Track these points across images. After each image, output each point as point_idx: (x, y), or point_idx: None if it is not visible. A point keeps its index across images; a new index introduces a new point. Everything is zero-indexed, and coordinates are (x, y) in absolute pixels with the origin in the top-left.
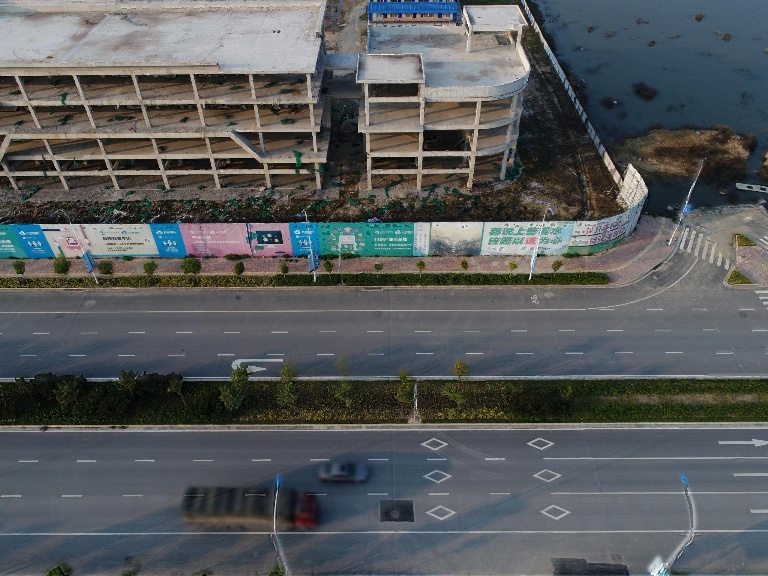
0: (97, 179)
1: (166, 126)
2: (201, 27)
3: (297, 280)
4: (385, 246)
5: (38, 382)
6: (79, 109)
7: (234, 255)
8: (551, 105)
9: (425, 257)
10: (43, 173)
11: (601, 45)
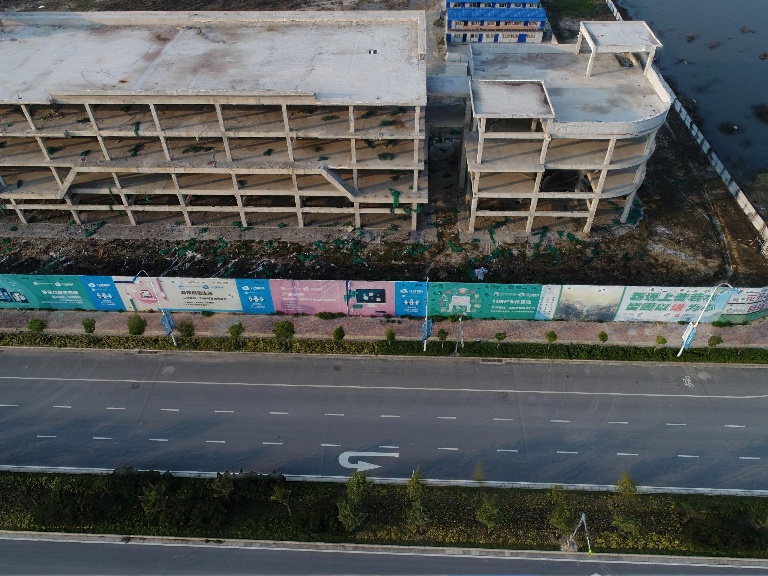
0: (166, 212)
1: (249, 160)
2: (286, 45)
3: (404, 348)
4: (504, 308)
5: (118, 479)
6: (150, 137)
7: (328, 313)
8: (663, 130)
9: (549, 321)
10: (109, 207)
11: (706, 58)
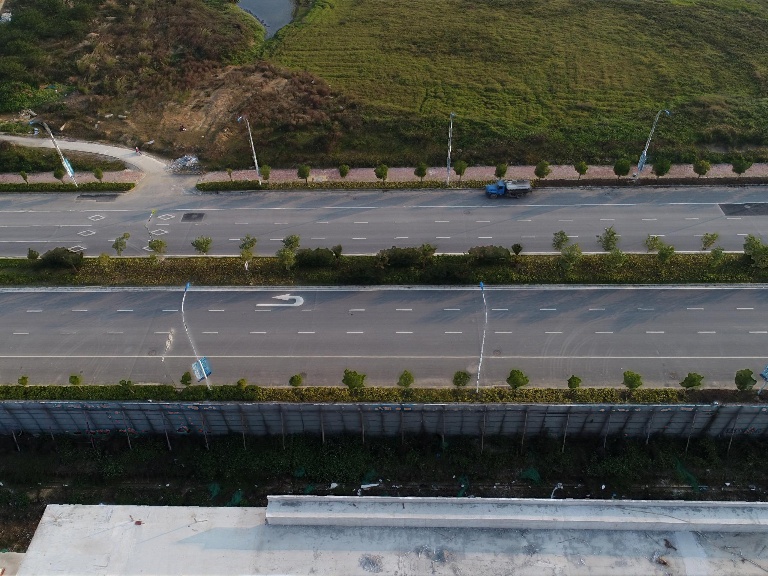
0: None
1: None
2: None
3: (231, 388)
4: (103, 424)
5: (462, 268)
6: None
7: None
8: None
9: None
10: None
11: None
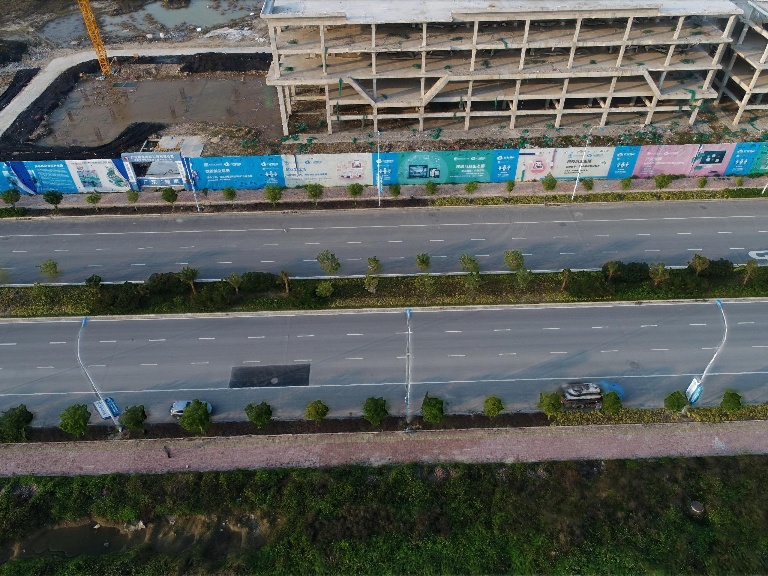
0: (484, 121)
1: (583, 67)
2: None
3: (748, 192)
4: None
5: None
6: (487, 56)
7: (673, 175)
8: None
9: None
10: (453, 114)
11: None
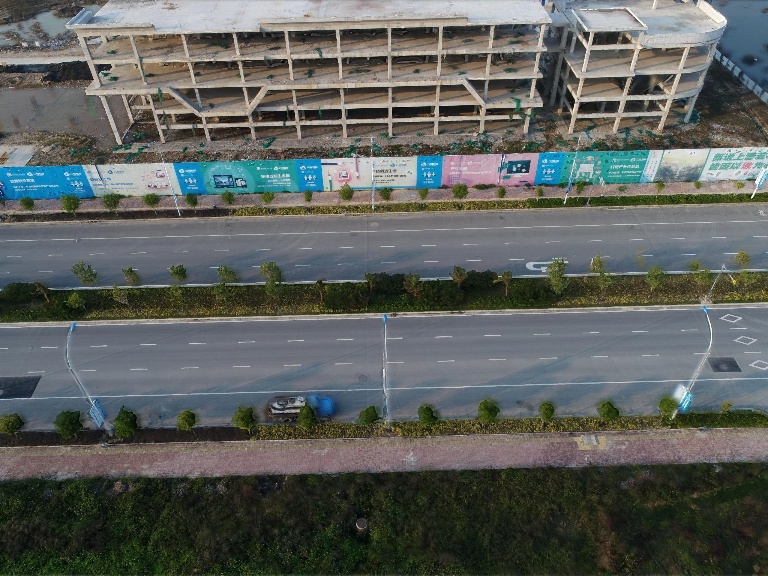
0: (321, 130)
1: (404, 76)
2: None
3: (549, 202)
4: (618, 173)
5: (377, 279)
6: (316, 65)
7: (483, 185)
8: None
9: (650, 183)
10: (283, 123)
11: None
